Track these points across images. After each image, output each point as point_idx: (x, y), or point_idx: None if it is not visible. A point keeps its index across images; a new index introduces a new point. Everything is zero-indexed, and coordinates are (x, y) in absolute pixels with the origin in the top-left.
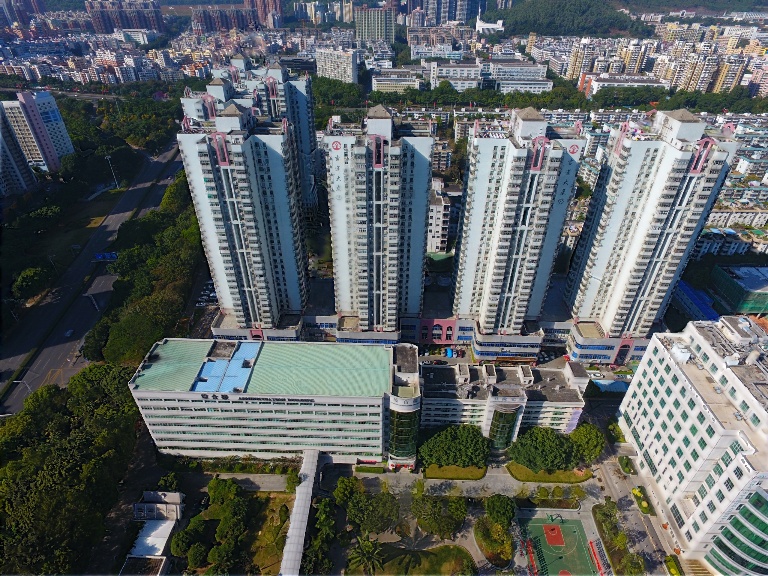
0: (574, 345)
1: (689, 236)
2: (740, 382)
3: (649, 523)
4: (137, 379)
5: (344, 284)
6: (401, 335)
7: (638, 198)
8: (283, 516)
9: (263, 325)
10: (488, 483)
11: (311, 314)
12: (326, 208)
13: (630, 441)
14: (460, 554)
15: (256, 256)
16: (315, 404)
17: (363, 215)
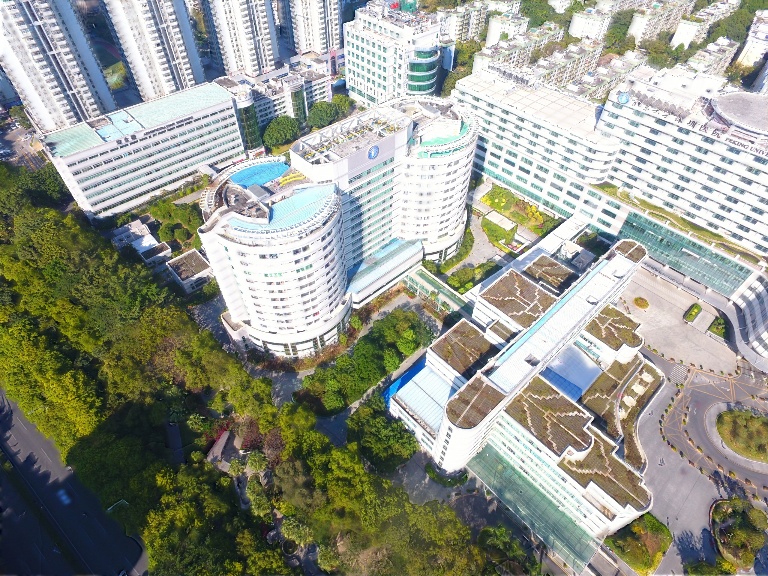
0: None
1: None
2: (386, 22)
3: None
4: (55, 155)
5: (141, 71)
6: None
7: None
8: None
9: None
10: None
11: None
12: (95, 5)
13: (359, 100)
14: None
15: (67, 54)
16: (194, 121)
17: None
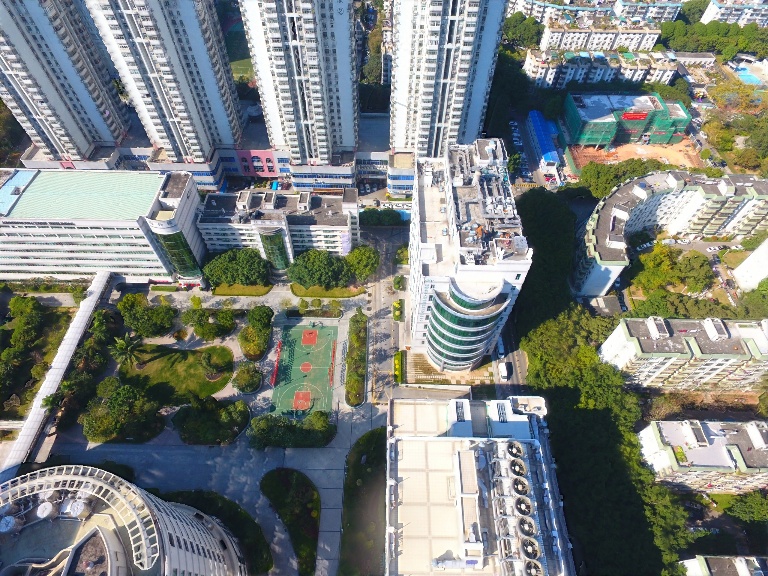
0: (387, 176)
1: (469, 52)
2: (452, 201)
3: (397, 328)
4: None
5: (146, 112)
6: (223, 168)
7: (422, 7)
8: (64, 324)
9: (72, 157)
10: (269, 298)
11: (128, 146)
12: None
13: None
14: (223, 352)
15: (25, 78)
16: (78, 227)
17: (117, 28)
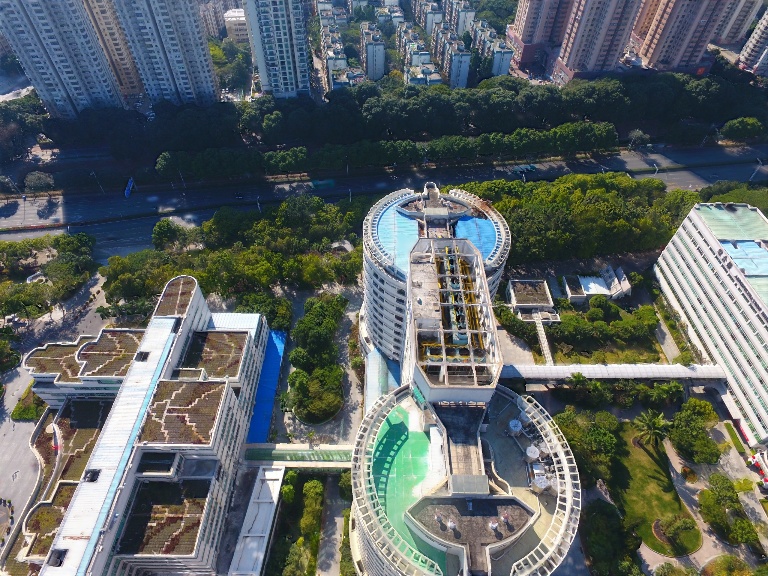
0: None
1: None
2: None
3: None
4: (705, 207)
5: None
6: None
7: None
8: (650, 359)
9: None
10: None
11: None
12: None
13: None
14: (693, 536)
15: None
16: None
17: None
